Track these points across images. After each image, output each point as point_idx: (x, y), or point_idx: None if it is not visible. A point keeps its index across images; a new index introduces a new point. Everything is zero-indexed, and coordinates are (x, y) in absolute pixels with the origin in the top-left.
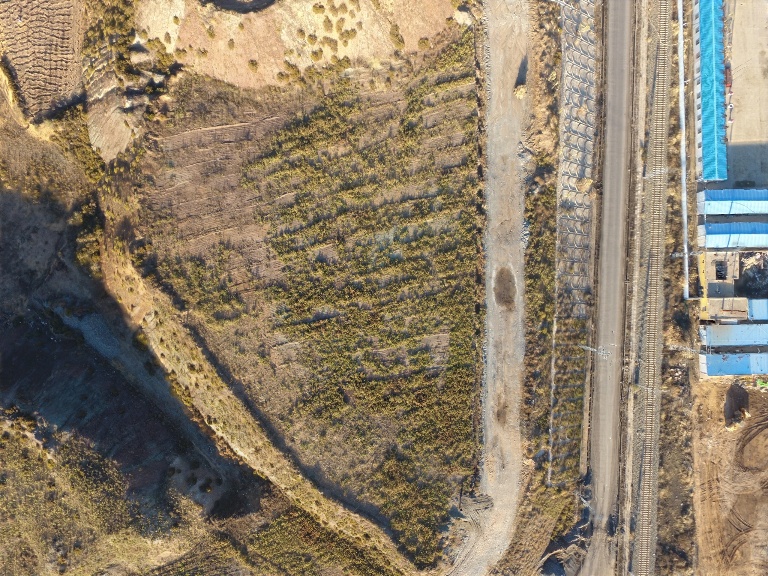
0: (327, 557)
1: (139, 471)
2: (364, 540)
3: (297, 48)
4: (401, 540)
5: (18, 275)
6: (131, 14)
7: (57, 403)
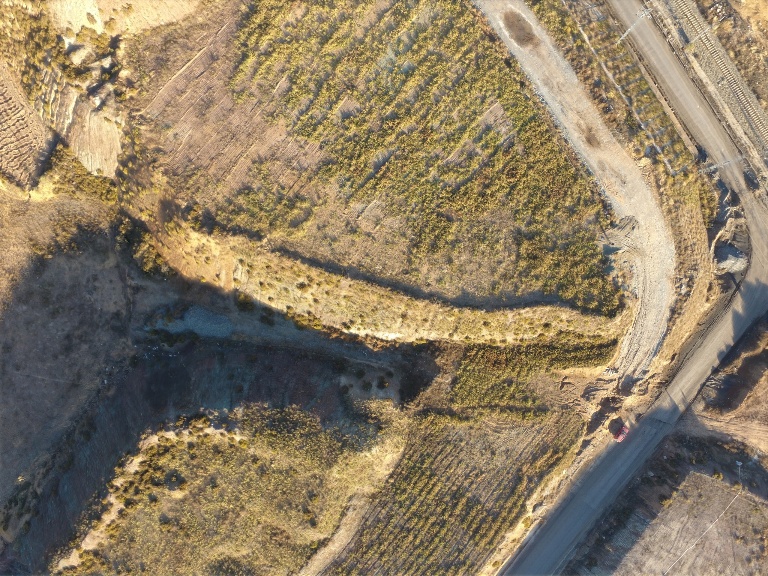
0: (525, 370)
1: (319, 402)
2: (547, 330)
3: None
4: (579, 304)
5: (107, 324)
6: (47, 23)
7: (213, 393)
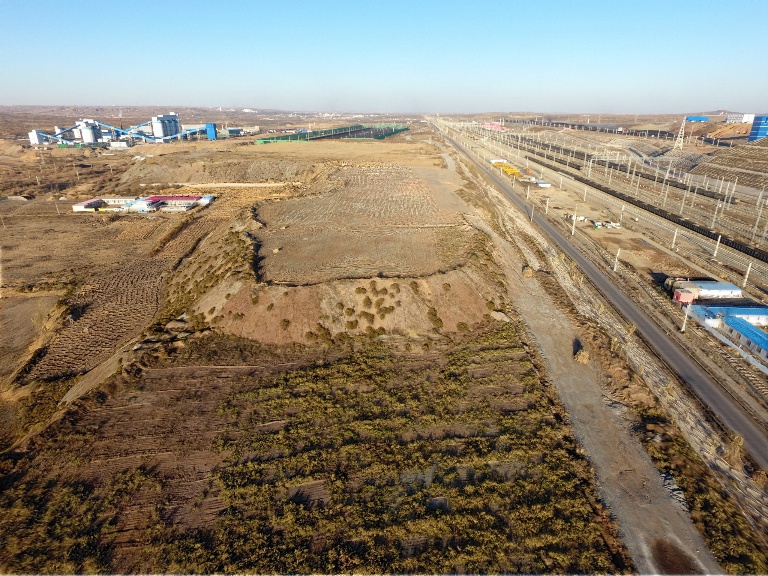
0: None
1: None
2: None
3: (333, 316)
4: None
5: None
6: None
7: None
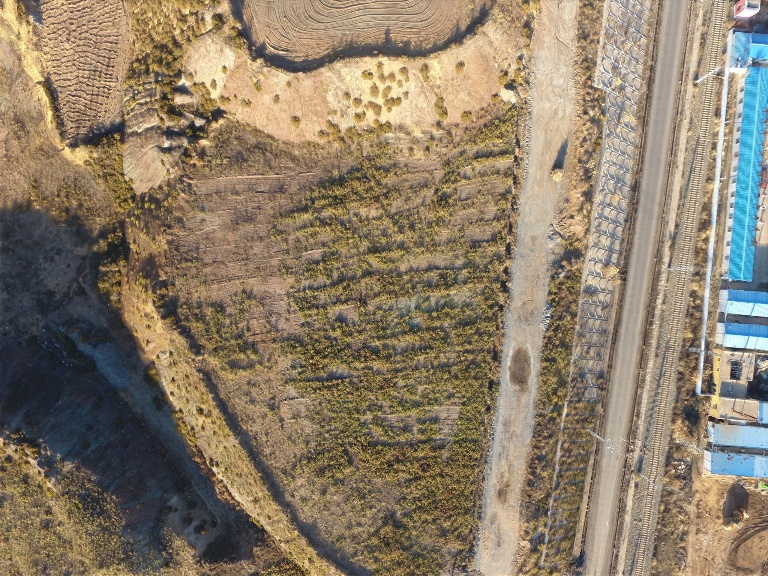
0: None
1: (136, 508)
2: None
3: (341, 109)
4: None
5: (37, 294)
6: (180, 56)
7: (63, 431)
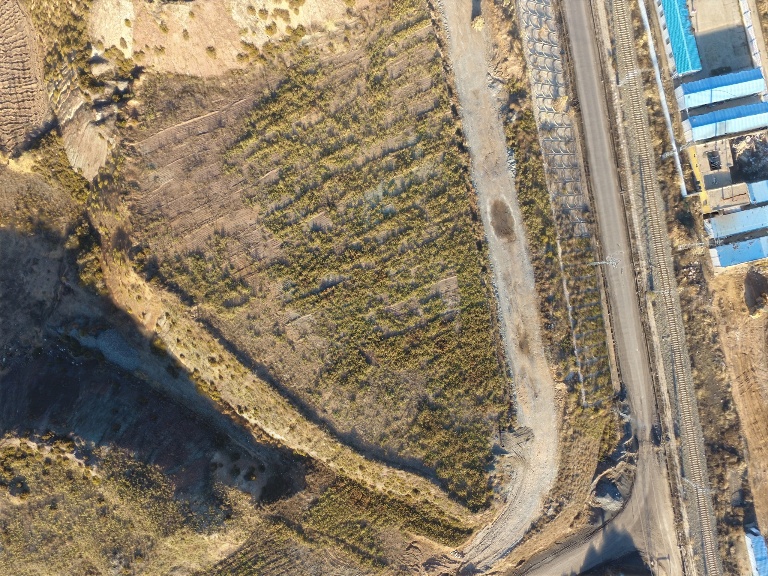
0: (381, 520)
1: (182, 471)
2: (414, 495)
3: (250, 26)
4: (450, 487)
5: (28, 308)
6: (83, 28)
7: (90, 421)
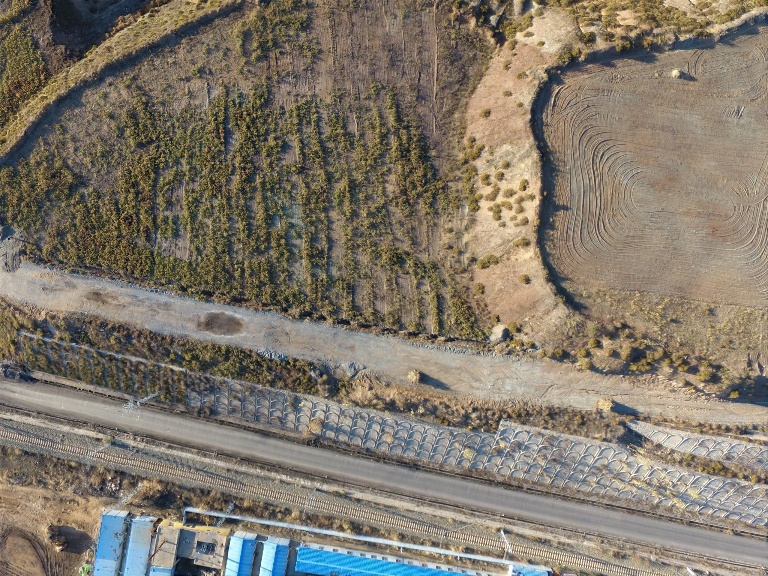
0: None
1: None
2: (0, 138)
3: (494, 160)
4: None
5: None
6: (561, 4)
7: None
